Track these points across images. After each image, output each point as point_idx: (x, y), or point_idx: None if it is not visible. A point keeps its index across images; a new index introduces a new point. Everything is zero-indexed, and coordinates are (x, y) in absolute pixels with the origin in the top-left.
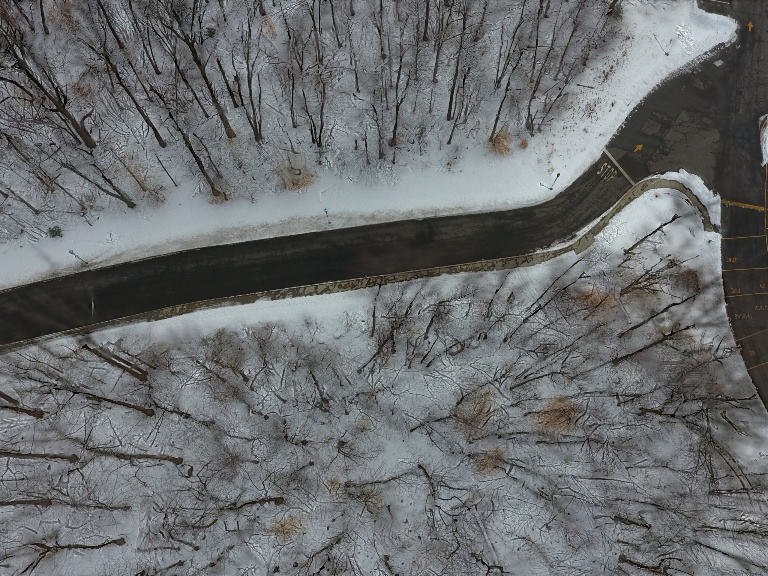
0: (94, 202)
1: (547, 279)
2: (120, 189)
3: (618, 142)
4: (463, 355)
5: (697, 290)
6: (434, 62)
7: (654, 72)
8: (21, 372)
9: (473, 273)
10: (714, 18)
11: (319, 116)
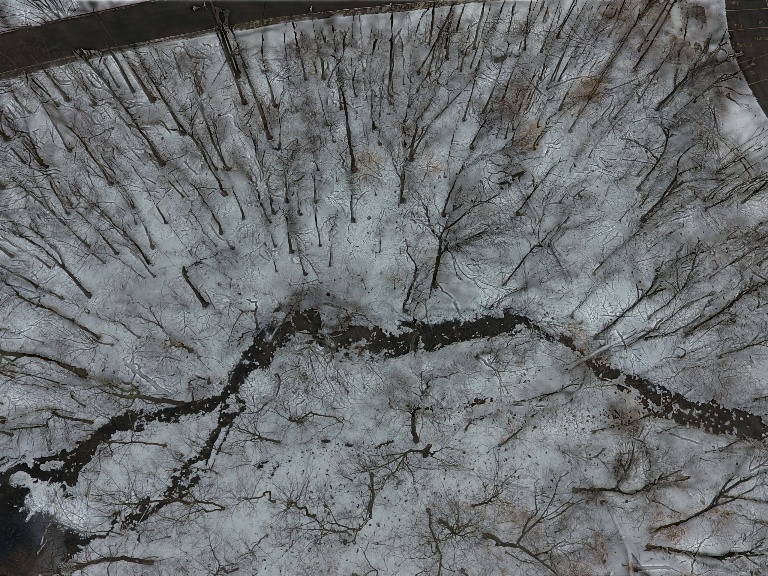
0: None
1: (576, 6)
2: None
3: None
4: (506, 62)
5: (705, 23)
6: None
7: None
8: (137, 65)
9: (513, 0)
10: None
11: None
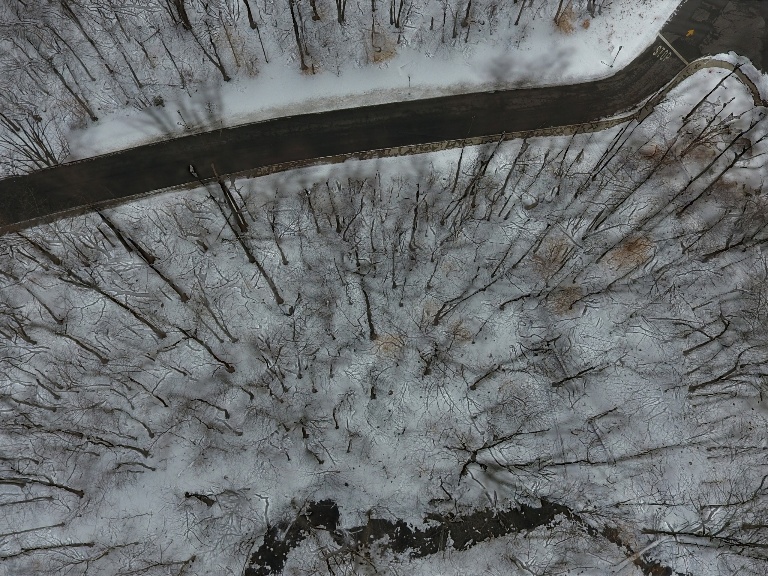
0: (192, 76)
1: (612, 143)
2: None
3: (671, 27)
4: (538, 209)
5: (751, 156)
6: None
7: None
8: (134, 221)
9: (544, 137)
10: None
11: None
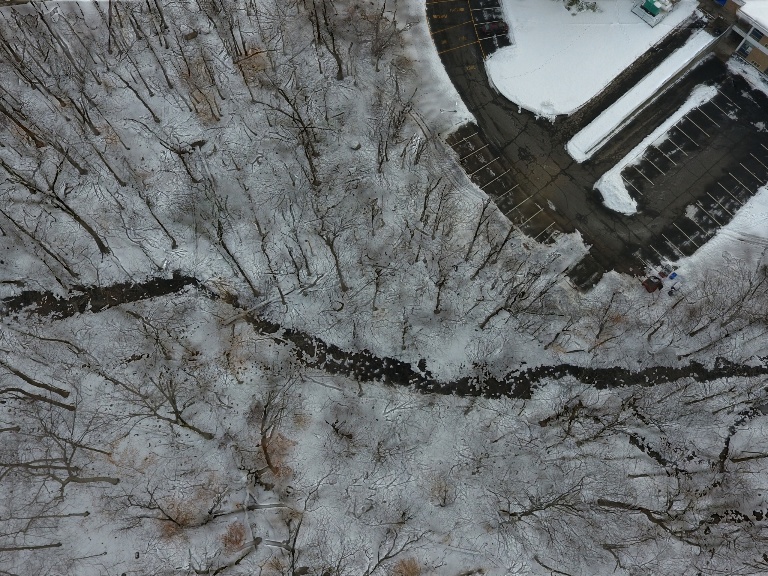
0: None
1: None
2: None
3: None
4: (196, 39)
5: None
6: None
7: None
8: None
9: None
10: None
11: None
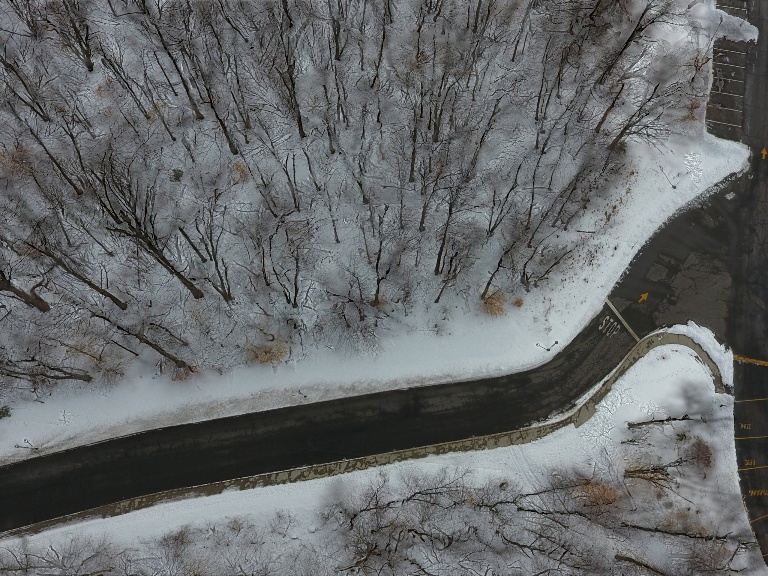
0: None
1: (544, 459)
2: (73, 367)
3: (621, 291)
4: (451, 550)
5: (708, 464)
6: (420, 215)
7: (660, 208)
8: None
9: (462, 453)
10: (725, 146)
11: (293, 283)
